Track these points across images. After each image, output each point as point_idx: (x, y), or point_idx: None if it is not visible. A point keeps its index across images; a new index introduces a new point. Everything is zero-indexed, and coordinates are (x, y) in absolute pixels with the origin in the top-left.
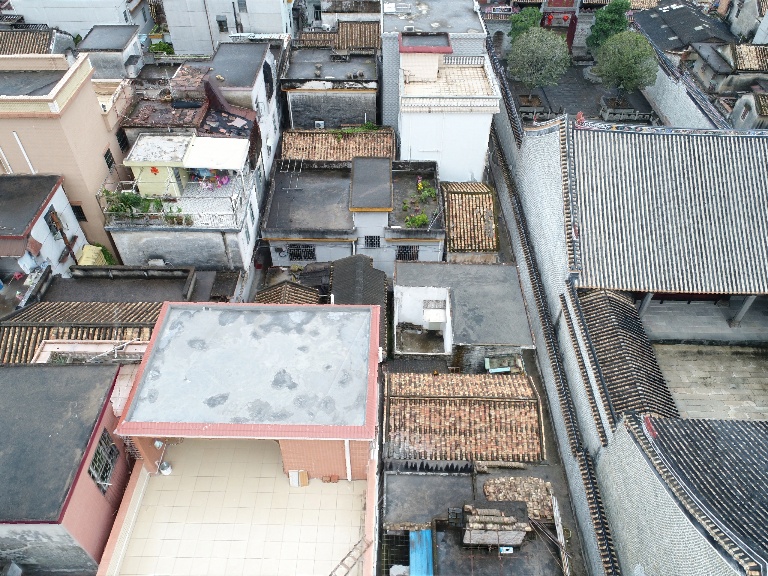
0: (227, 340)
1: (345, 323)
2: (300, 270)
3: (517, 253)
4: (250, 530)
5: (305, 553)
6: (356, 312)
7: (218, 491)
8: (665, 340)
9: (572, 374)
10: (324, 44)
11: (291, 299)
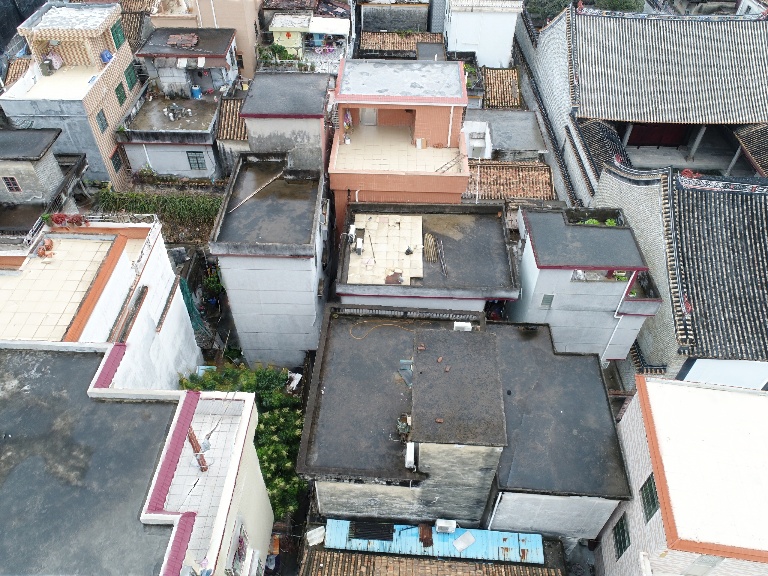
0: (381, 73)
1: (444, 68)
2: None
3: None
4: (398, 162)
5: (429, 169)
6: (450, 64)
7: (378, 150)
8: (639, 168)
9: (573, 173)
10: None
11: None
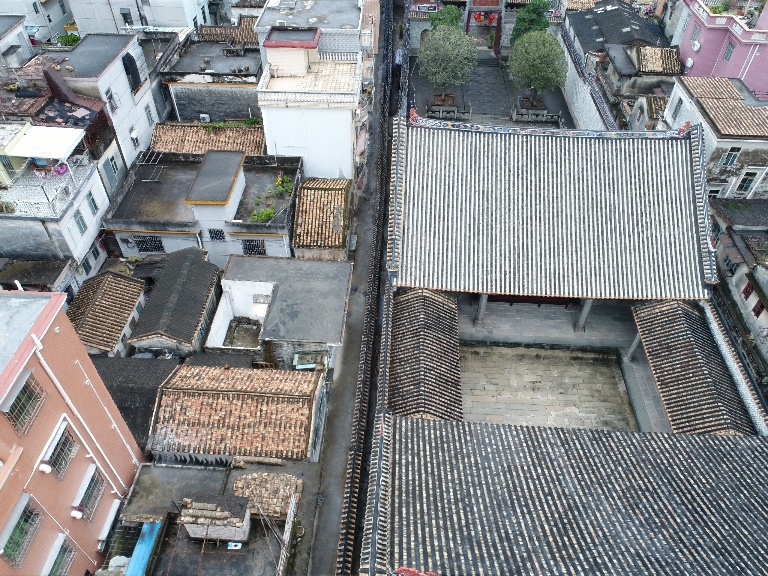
0: None
1: (21, 309)
2: (138, 261)
3: None
4: None
5: None
6: (38, 299)
7: None
8: (505, 343)
9: None
10: (223, 38)
11: (109, 289)
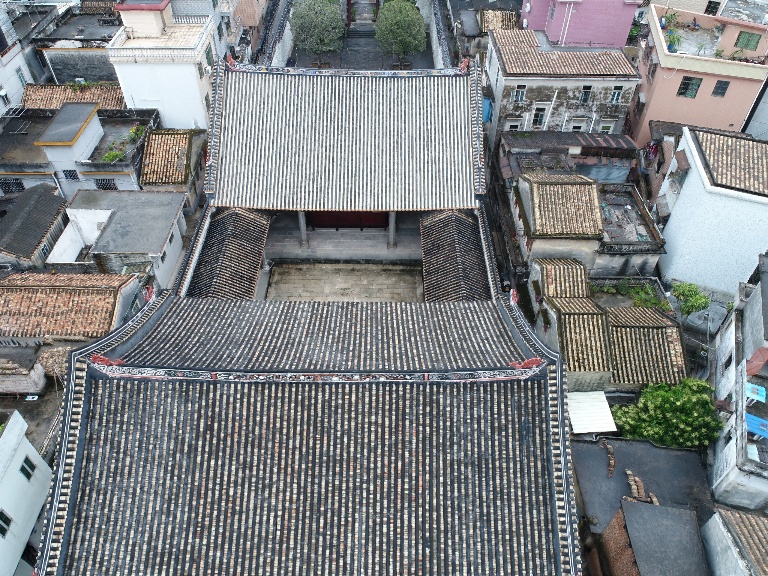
0: None
1: None
2: None
3: None
4: None
5: None
6: None
7: None
8: (326, 260)
9: None
10: (102, 11)
11: None
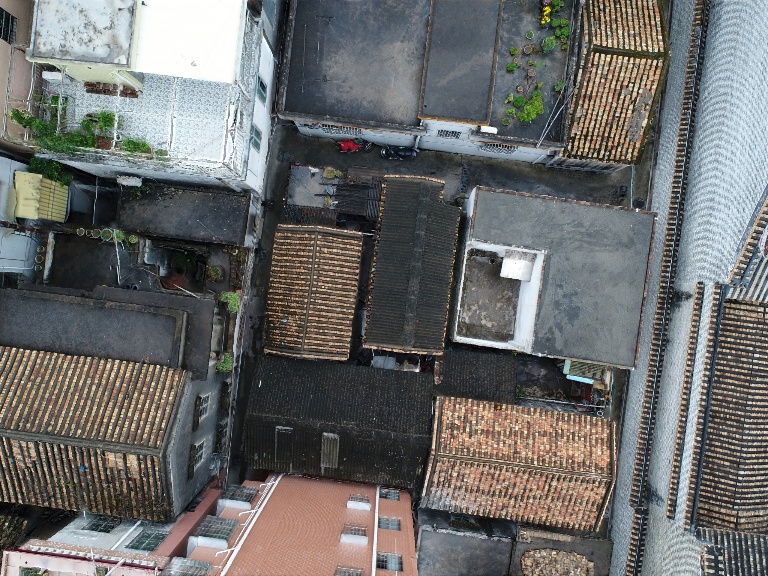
0: None
1: None
2: (337, 177)
3: (665, 134)
4: None
5: None
6: None
7: None
8: None
9: (668, 383)
10: None
11: (323, 260)
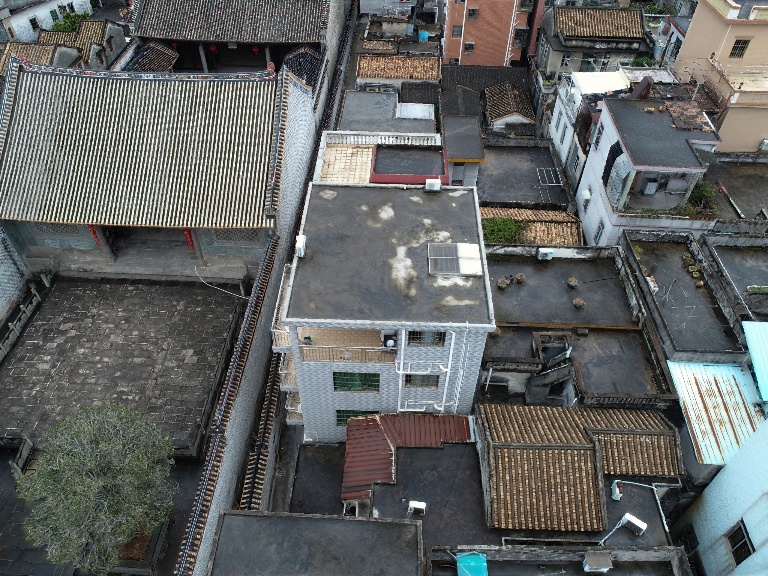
0: None
1: None
2: None
3: None
4: None
5: None
6: None
7: None
8: None
9: None
10: (602, 401)
11: (508, 107)
